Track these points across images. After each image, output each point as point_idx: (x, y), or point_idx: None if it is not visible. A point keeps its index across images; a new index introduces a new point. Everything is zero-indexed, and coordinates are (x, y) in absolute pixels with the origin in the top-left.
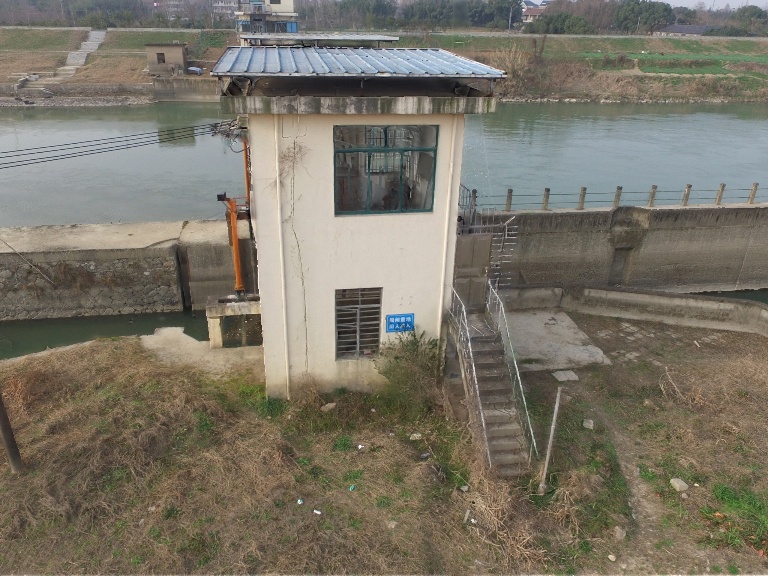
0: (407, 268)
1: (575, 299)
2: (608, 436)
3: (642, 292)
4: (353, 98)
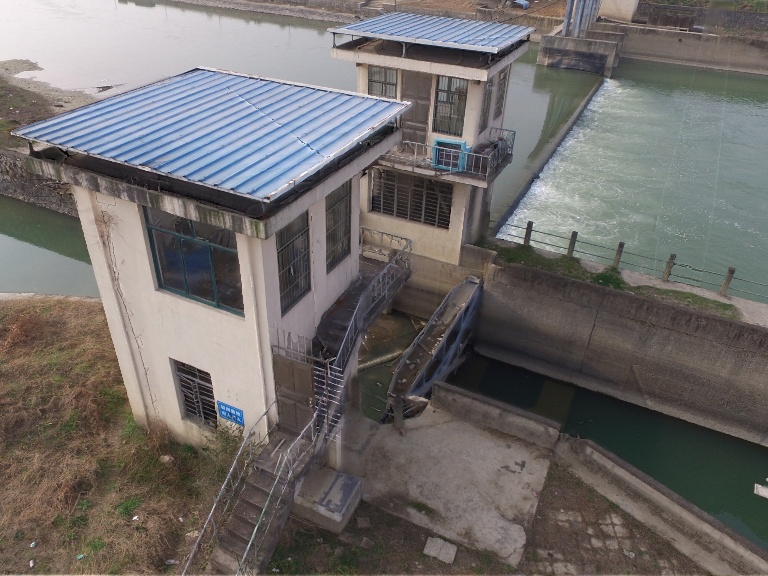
0: (228, 365)
1: (573, 451)
2: None
3: (658, 489)
4: (124, 185)
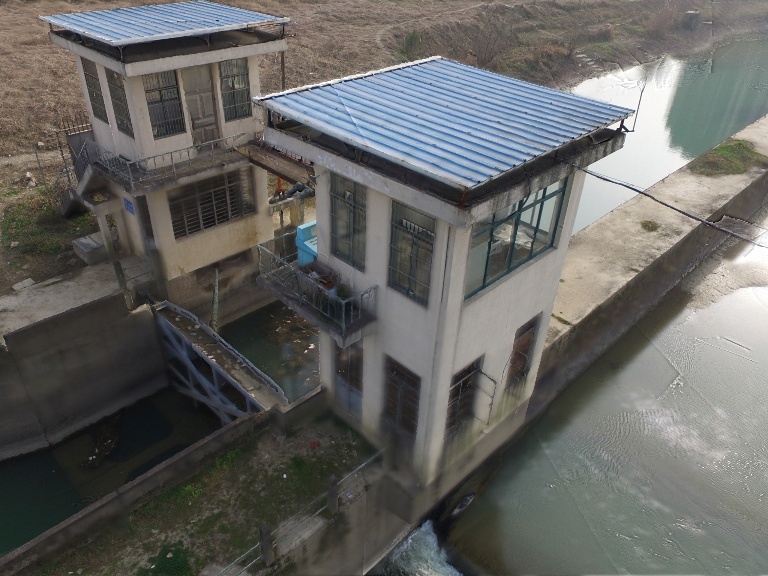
0: None
1: None
2: (3, 247)
3: None
4: None
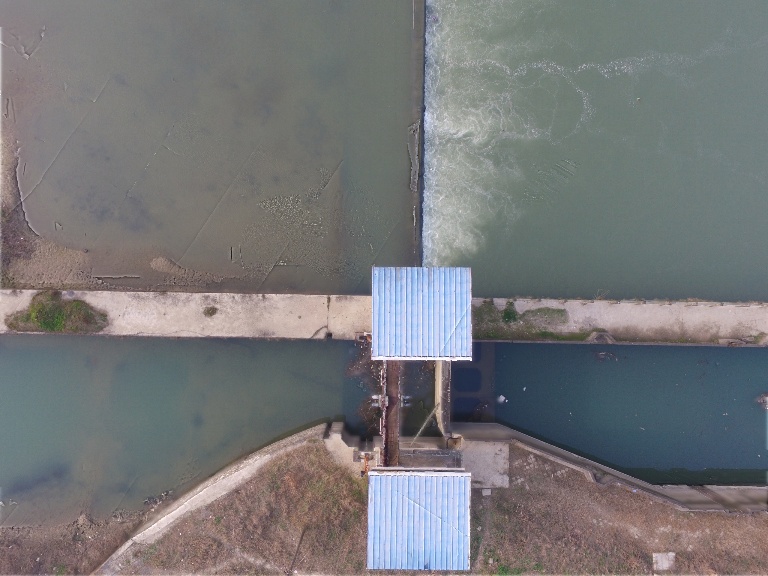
0: None
1: (516, 441)
2: (483, 532)
3: None
4: None
